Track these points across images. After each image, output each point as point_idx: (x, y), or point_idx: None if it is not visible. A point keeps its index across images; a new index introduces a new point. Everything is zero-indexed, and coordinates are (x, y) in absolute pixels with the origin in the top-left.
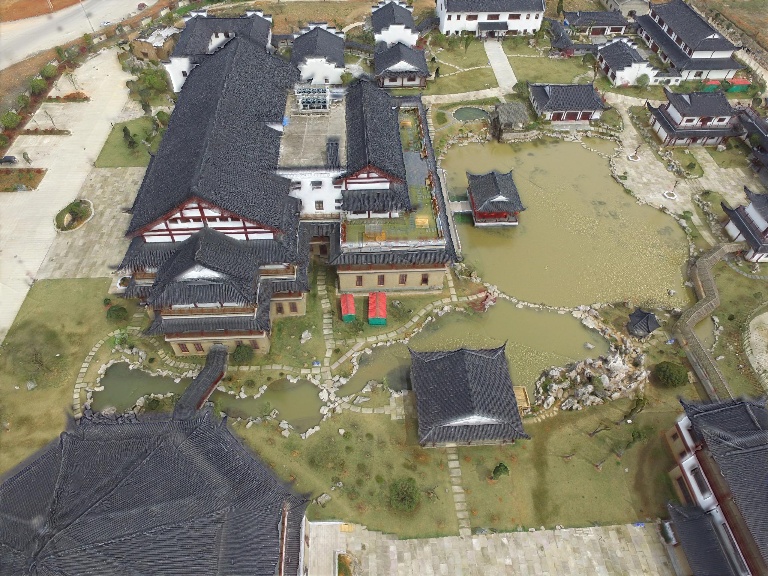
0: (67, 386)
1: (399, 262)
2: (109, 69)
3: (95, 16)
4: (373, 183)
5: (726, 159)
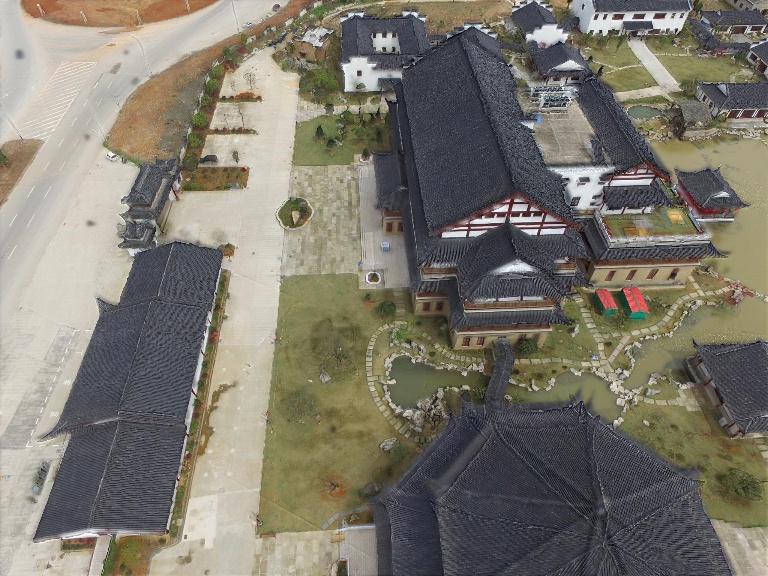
0: (359, 379)
1: (665, 257)
2: (268, 69)
3: (233, 17)
4: (637, 179)
5: None
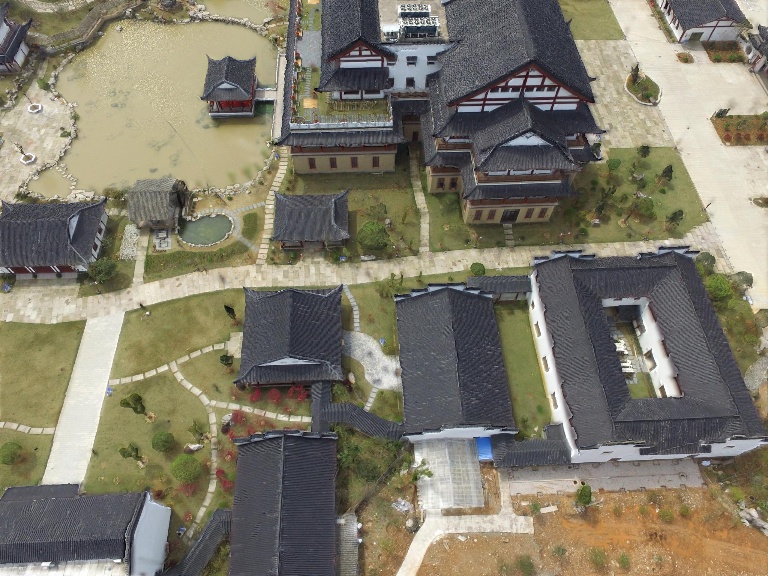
0: None
1: None
2: None
3: None
4: None
5: None
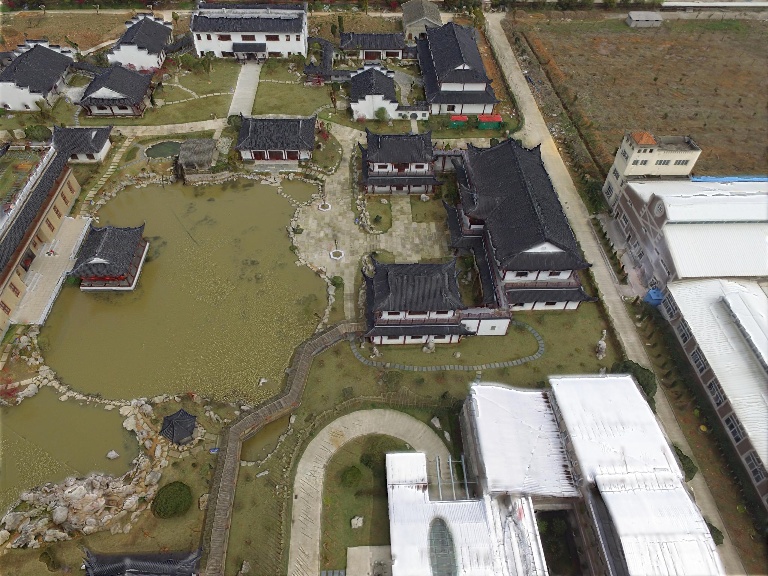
0: None
1: None
2: None
3: None
4: None
5: (426, 211)
